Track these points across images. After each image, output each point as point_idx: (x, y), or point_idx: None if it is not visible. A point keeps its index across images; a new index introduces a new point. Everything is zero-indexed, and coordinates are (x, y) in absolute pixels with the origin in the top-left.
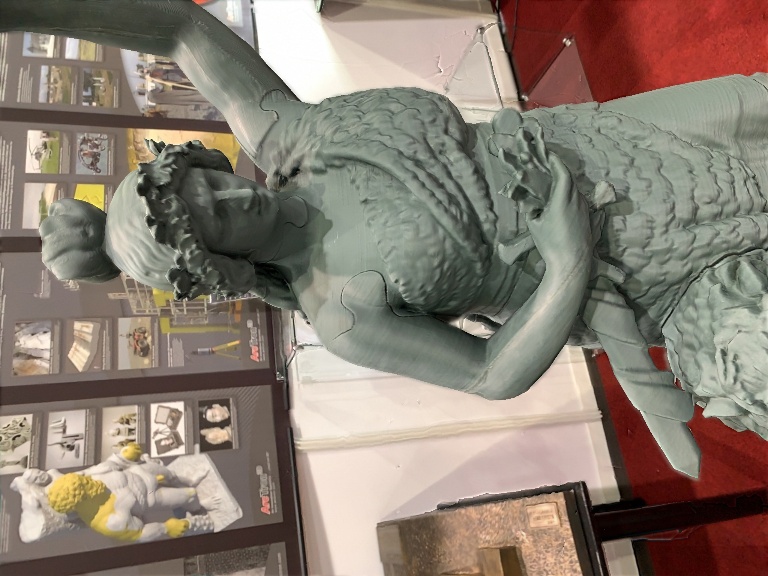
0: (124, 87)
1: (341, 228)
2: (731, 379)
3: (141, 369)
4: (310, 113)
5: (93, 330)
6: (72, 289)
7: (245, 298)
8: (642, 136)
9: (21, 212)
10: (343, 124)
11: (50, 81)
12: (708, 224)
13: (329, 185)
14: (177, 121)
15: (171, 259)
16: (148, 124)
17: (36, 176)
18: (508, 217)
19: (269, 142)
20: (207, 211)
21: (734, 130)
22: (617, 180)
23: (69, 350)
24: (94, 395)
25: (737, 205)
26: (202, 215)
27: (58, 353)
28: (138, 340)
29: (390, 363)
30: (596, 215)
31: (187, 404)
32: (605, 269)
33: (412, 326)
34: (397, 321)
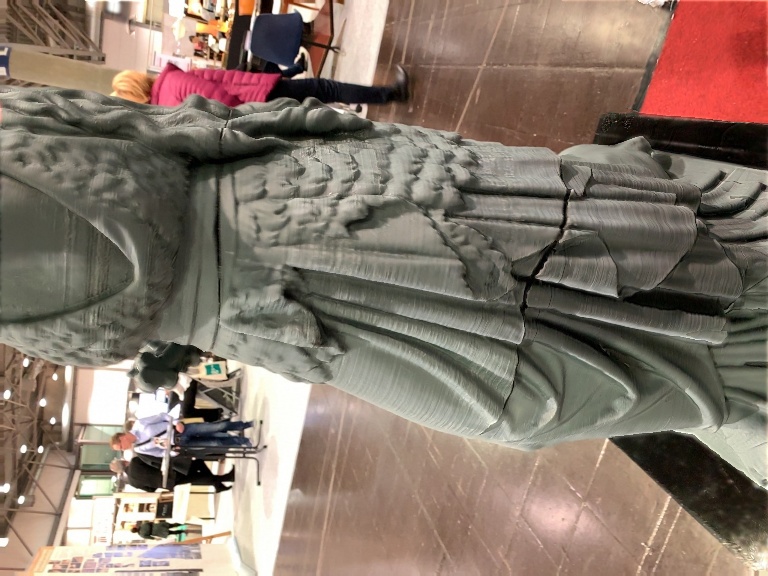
0: None
1: None
2: None
3: None
4: None
5: None
6: None
7: None
8: None
9: None
10: None
11: None
12: None
13: None
14: None
15: None
16: None
17: None
18: None
19: None
20: None
21: None
22: None
23: None
24: None
25: None
26: None
27: None
28: None
29: None
30: None
31: None
32: None
33: None
34: None
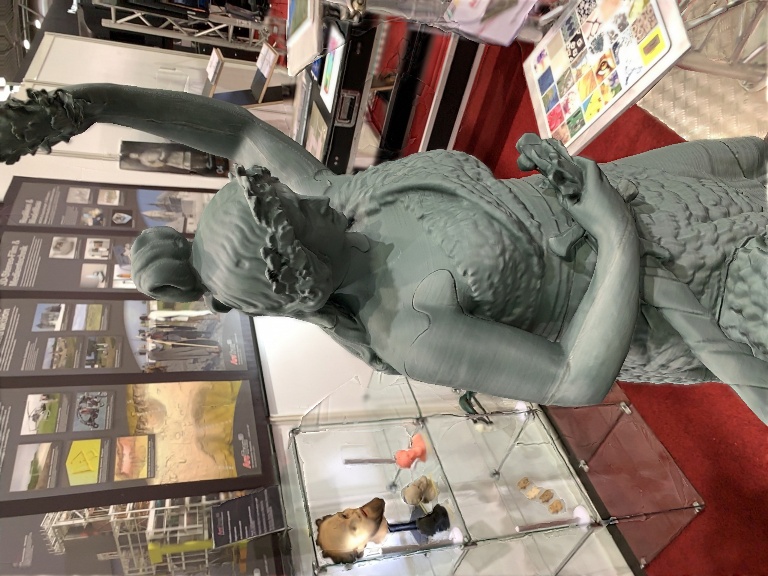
0: (126, 349)
1: (403, 245)
2: None
3: None
4: (359, 174)
5: None
6: (57, 553)
7: (252, 537)
8: (638, 172)
9: (10, 475)
10: (390, 172)
11: (55, 350)
12: None
13: (385, 219)
14: (176, 374)
15: (263, 240)
16: (148, 379)
17: (31, 437)
18: (549, 224)
19: None
20: (293, 203)
21: (710, 168)
22: None
23: None
24: None
25: (739, 208)
26: (289, 205)
27: None
28: None
29: (471, 364)
30: None
31: None
32: (650, 245)
33: (486, 324)
34: (470, 319)
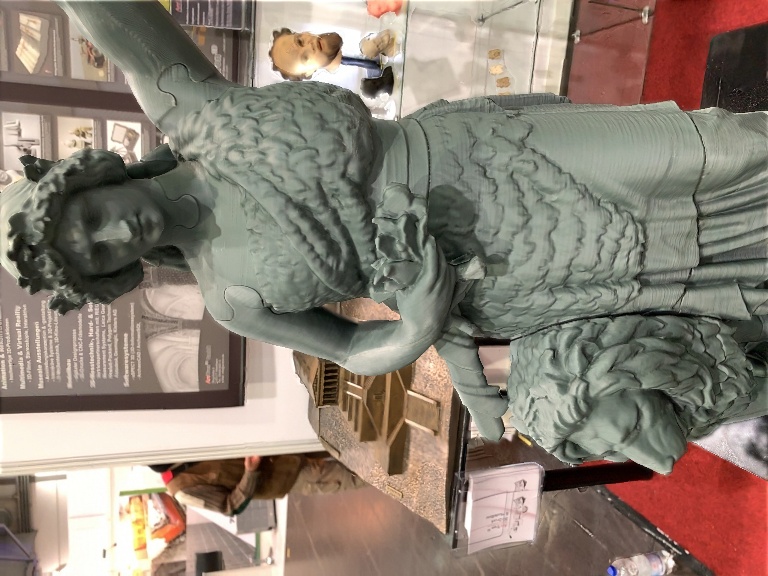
0: None
1: (228, 241)
2: (527, 423)
3: (96, 81)
4: (209, 113)
5: (41, 27)
6: None
7: (209, 26)
8: (551, 190)
9: None
10: (239, 143)
11: None
12: (573, 290)
13: (222, 194)
14: None
15: None
16: None
17: None
18: None
19: (167, 123)
20: (83, 256)
21: (650, 191)
22: (503, 242)
23: (16, 46)
24: (47, 101)
25: (610, 273)
26: (79, 260)
27: (5, 48)
28: (92, 48)
29: None
30: (463, 285)
31: (144, 127)
32: (458, 326)
33: (286, 324)
34: (272, 319)
